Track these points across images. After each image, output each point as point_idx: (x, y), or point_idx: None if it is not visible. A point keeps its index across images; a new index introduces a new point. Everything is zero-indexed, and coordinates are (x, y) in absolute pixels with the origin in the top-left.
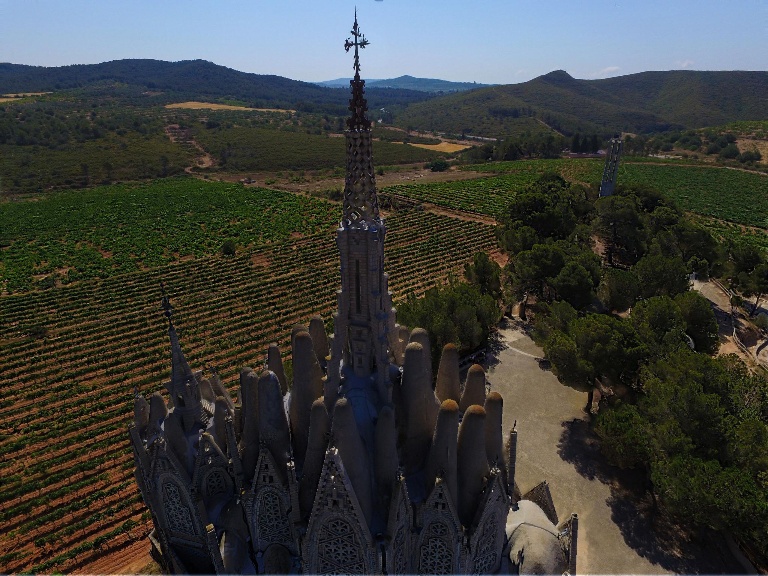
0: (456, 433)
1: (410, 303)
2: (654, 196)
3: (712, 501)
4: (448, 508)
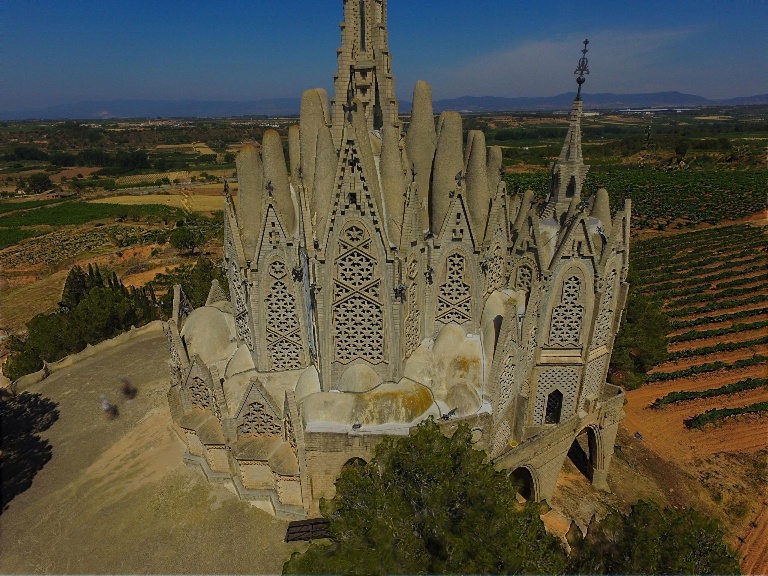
0: None
1: None
2: None
3: None
4: None
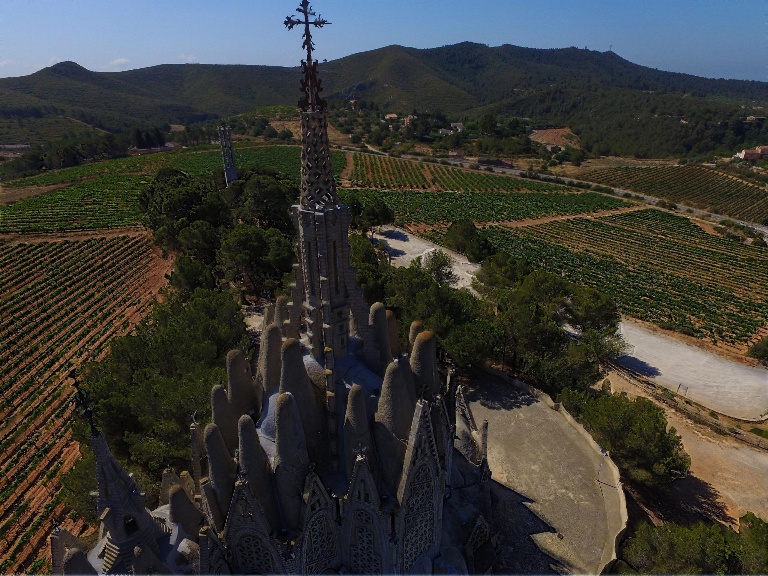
0: None
1: (142, 334)
2: (272, 173)
3: (482, 343)
4: (444, 416)
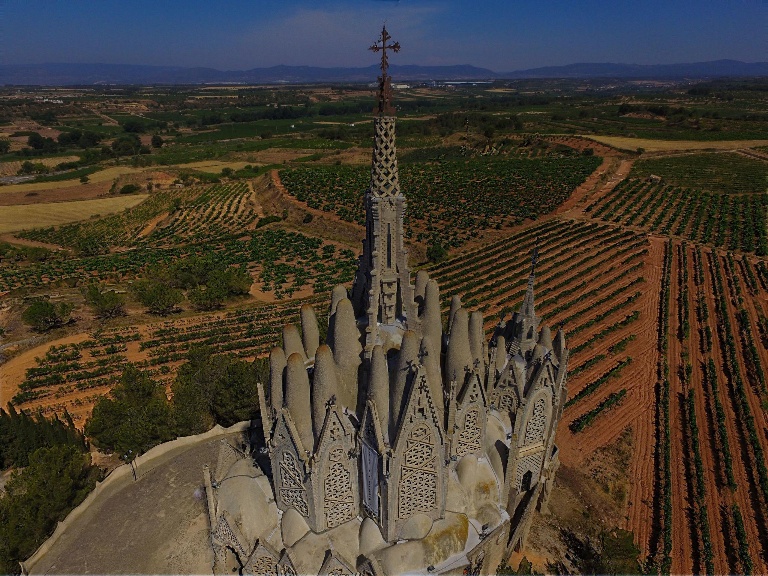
0: None
1: None
2: None
3: None
4: None
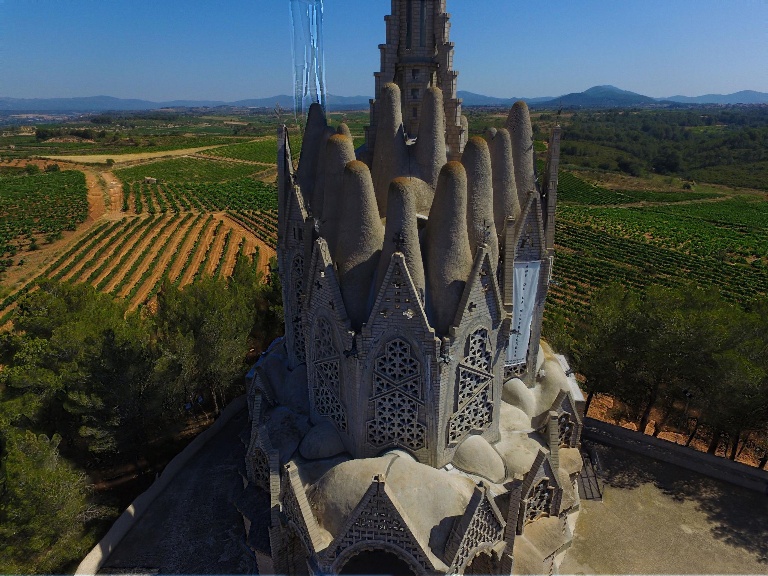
0: (331, 176)
1: None
2: None
3: None
4: None
